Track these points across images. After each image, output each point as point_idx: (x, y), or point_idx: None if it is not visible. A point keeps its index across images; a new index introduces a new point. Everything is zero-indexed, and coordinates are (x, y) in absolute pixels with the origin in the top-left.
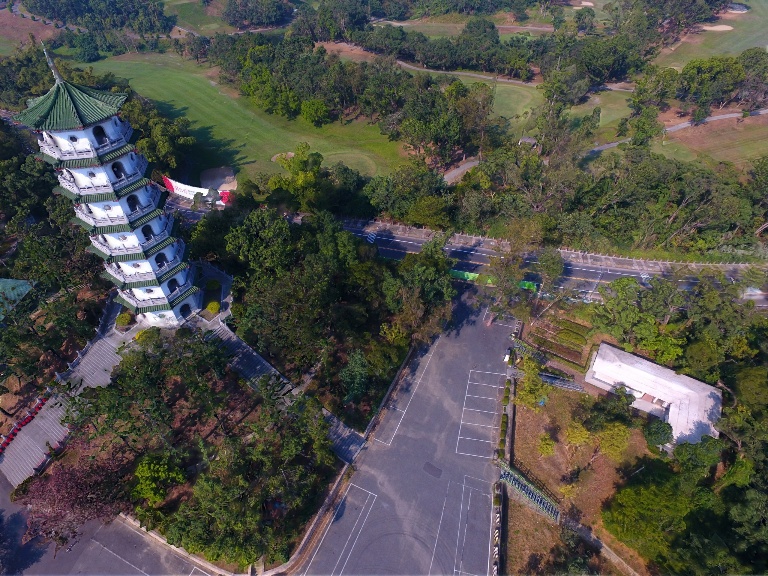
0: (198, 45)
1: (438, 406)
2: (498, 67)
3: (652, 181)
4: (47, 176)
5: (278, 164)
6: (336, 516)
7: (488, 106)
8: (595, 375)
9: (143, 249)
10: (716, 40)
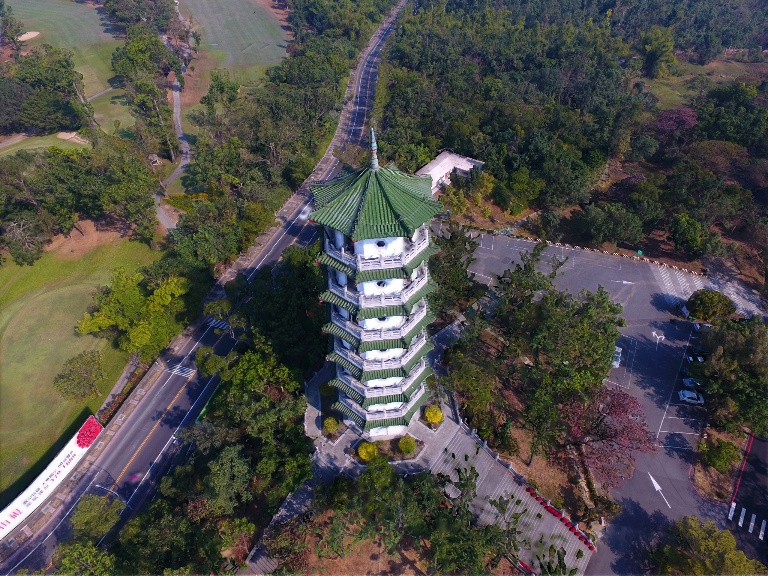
0: None
1: None
2: None
3: None
4: None
5: None
6: None
7: (142, 134)
8: None
9: None
10: None
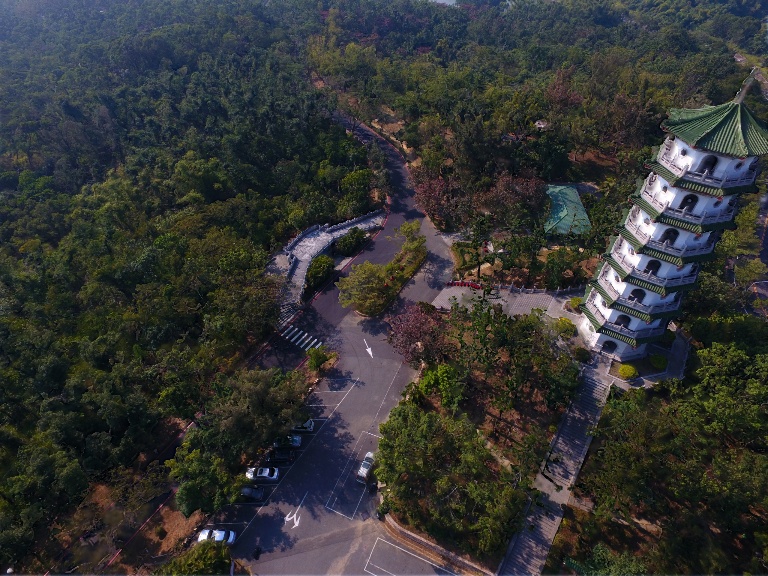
0: None
1: None
2: None
3: None
4: None
5: None
6: (439, 569)
7: None
8: None
9: (631, 273)
10: None
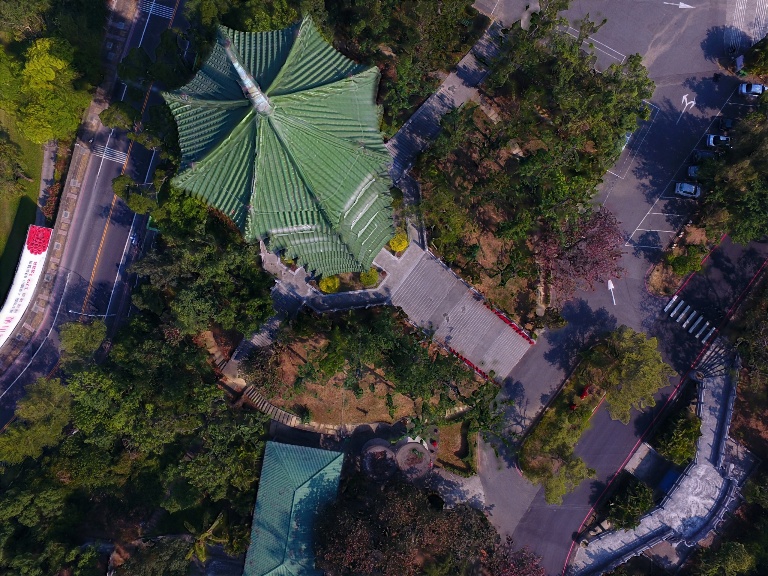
0: None
1: None
2: None
3: None
4: None
5: None
6: None
7: None
8: None
9: None
10: None
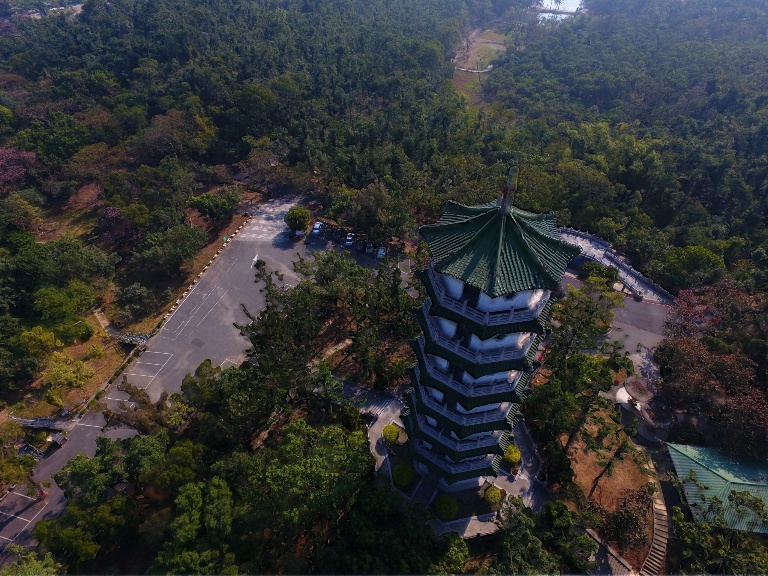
0: None
1: (168, 391)
2: None
3: None
4: None
5: None
6: None
7: None
8: None
9: None
10: None
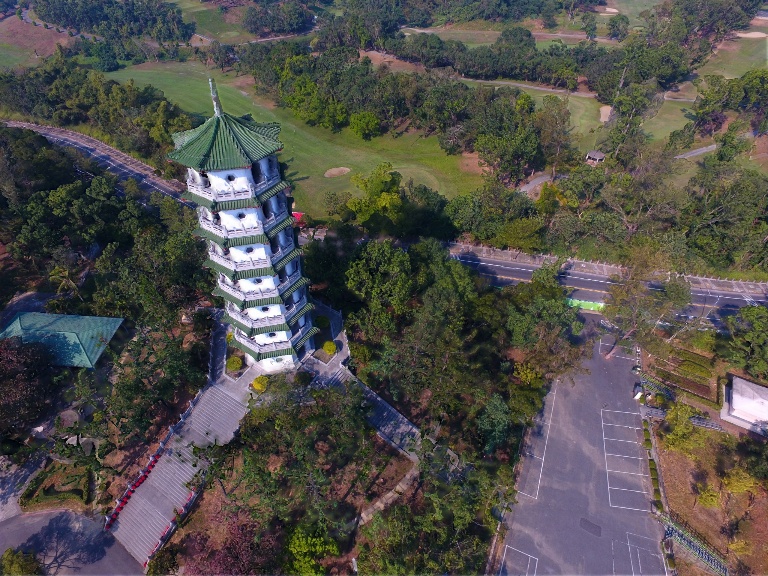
0: (223, 54)
1: (577, 452)
2: (542, 76)
3: (755, 200)
4: (114, 200)
5: (334, 180)
6: None
7: (568, 121)
8: (733, 412)
9: (279, 293)
10: (753, 47)
